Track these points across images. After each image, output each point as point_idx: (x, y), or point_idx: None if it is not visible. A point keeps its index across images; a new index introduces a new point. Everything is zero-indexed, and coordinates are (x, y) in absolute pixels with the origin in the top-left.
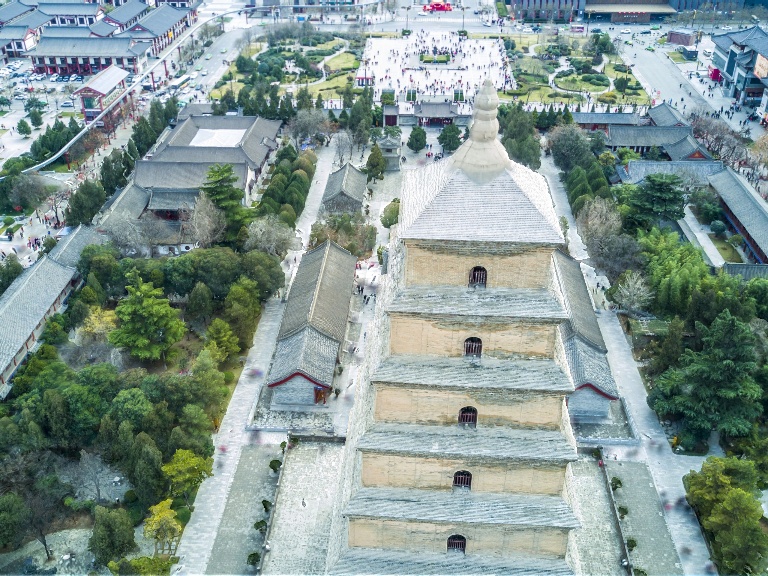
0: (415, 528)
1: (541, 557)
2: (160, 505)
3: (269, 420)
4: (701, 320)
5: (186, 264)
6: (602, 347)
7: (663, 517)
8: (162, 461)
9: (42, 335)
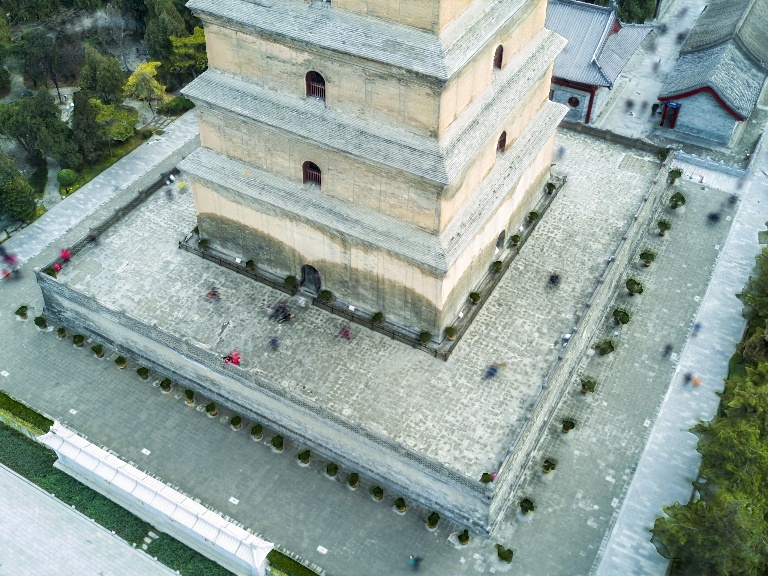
0: (270, 51)
1: (410, 130)
2: (148, 64)
3: None
4: None
5: None
6: (766, 66)
7: (718, 250)
8: None
9: None
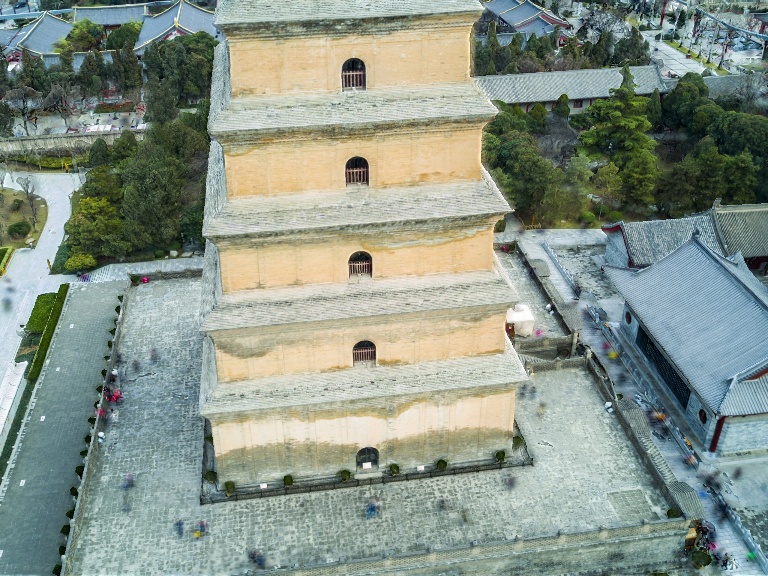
0: None
1: None
2: None
3: (574, 258)
4: None
5: (727, 118)
6: None
7: None
8: None
9: (574, 114)
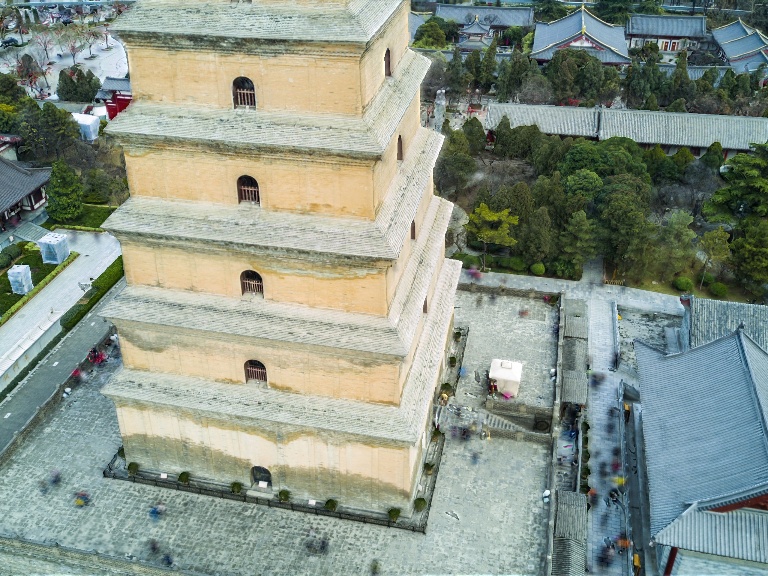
0: None
1: None
2: None
3: (643, 325)
4: None
5: None
6: None
7: None
8: (518, 223)
9: None
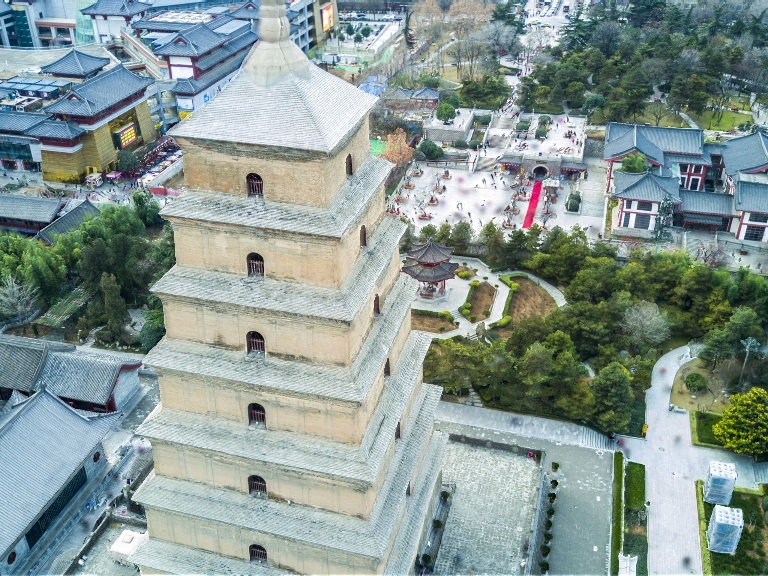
0: None
1: None
2: None
3: None
4: (105, 271)
5: None
6: None
7: None
8: None
9: None
